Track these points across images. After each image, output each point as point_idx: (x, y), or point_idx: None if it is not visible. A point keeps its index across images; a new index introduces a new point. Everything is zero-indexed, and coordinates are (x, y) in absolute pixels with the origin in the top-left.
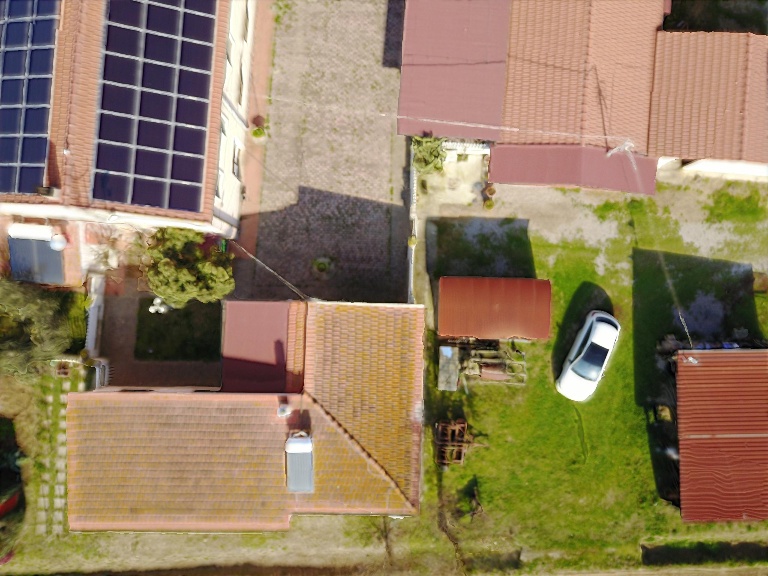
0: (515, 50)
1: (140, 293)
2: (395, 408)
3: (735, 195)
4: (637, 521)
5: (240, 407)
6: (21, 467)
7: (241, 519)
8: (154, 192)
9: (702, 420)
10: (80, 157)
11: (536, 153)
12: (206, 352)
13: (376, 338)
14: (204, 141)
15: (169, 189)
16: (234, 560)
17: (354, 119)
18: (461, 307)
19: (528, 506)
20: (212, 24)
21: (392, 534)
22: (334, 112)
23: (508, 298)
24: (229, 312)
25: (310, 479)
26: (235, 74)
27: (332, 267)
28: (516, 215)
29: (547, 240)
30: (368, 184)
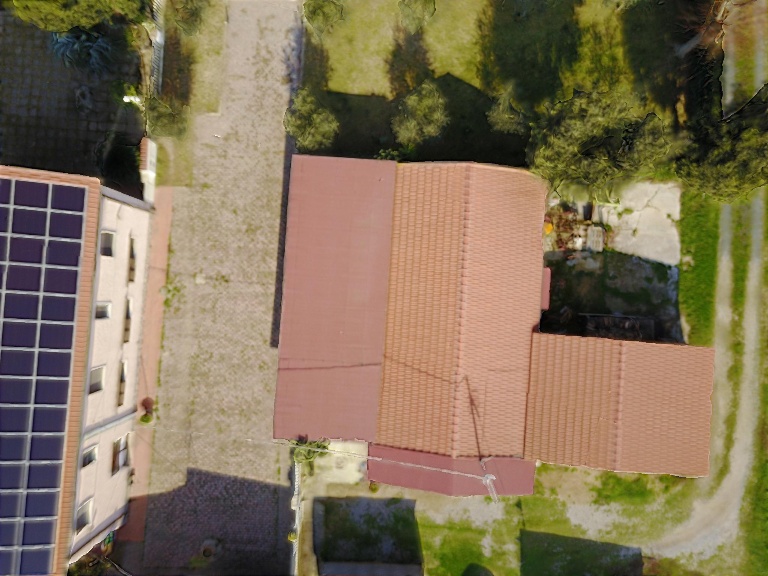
0: (391, 351)
1: None
2: None
3: (623, 477)
4: None
5: None
6: None
7: None
8: (5, 560)
9: None
10: None
11: (410, 458)
12: None
13: None
14: (58, 501)
15: (20, 556)
16: None
17: (242, 399)
18: None
19: None
20: (66, 385)
21: None
22: (222, 392)
23: None
24: None
25: None
26: (111, 386)
27: (220, 548)
28: (403, 495)
29: (434, 521)
30: (255, 464)
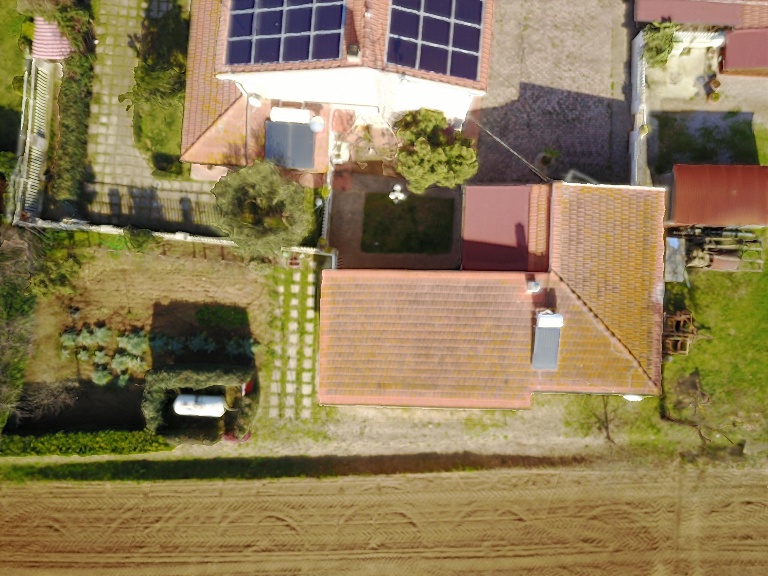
0: None
1: (366, 187)
2: (638, 289)
3: None
4: None
5: (487, 285)
6: (255, 353)
7: (485, 396)
8: (437, 59)
9: None
10: (376, 21)
11: None
12: (430, 244)
13: (619, 220)
14: (480, 12)
15: (450, 57)
16: (455, 448)
17: (575, 15)
18: (697, 193)
19: (752, 399)
20: None
21: (613, 425)
22: (555, 9)
23: (746, 184)
24: (469, 197)
25: (556, 356)
26: None
27: (553, 162)
28: (740, 109)
29: None
30: (589, 79)
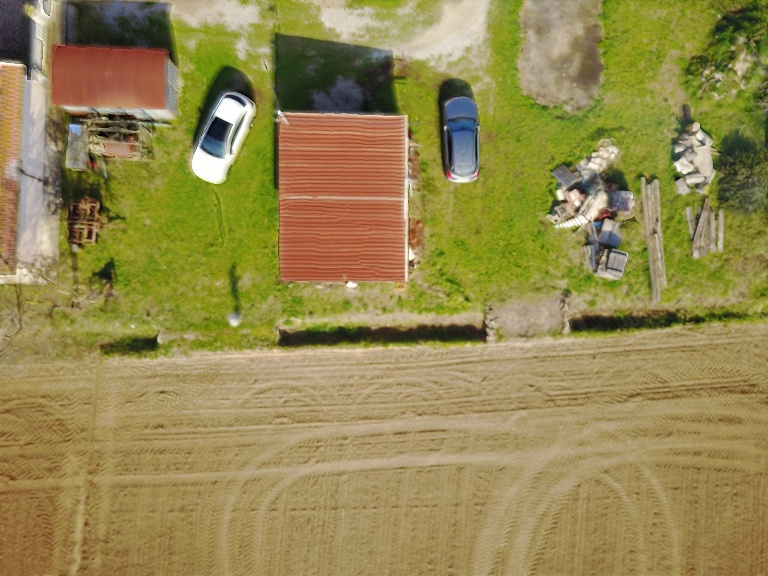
0: None
1: None
2: None
3: None
4: (274, 304)
5: None
6: None
7: None
8: None
9: (303, 182)
10: None
11: None
12: None
13: None
14: None
15: None
16: None
17: None
18: (74, 74)
19: (166, 289)
20: None
21: (26, 317)
22: None
23: (123, 66)
24: None
25: None
26: None
27: None
28: None
29: (190, 25)
30: None
